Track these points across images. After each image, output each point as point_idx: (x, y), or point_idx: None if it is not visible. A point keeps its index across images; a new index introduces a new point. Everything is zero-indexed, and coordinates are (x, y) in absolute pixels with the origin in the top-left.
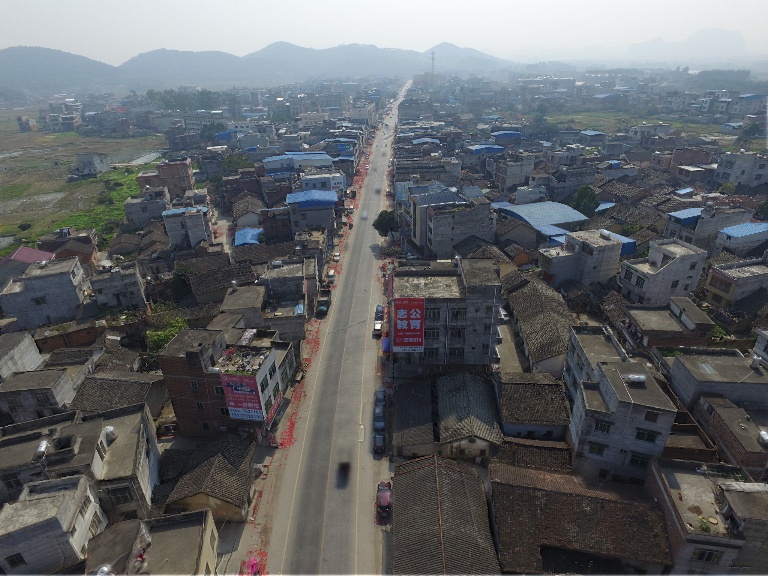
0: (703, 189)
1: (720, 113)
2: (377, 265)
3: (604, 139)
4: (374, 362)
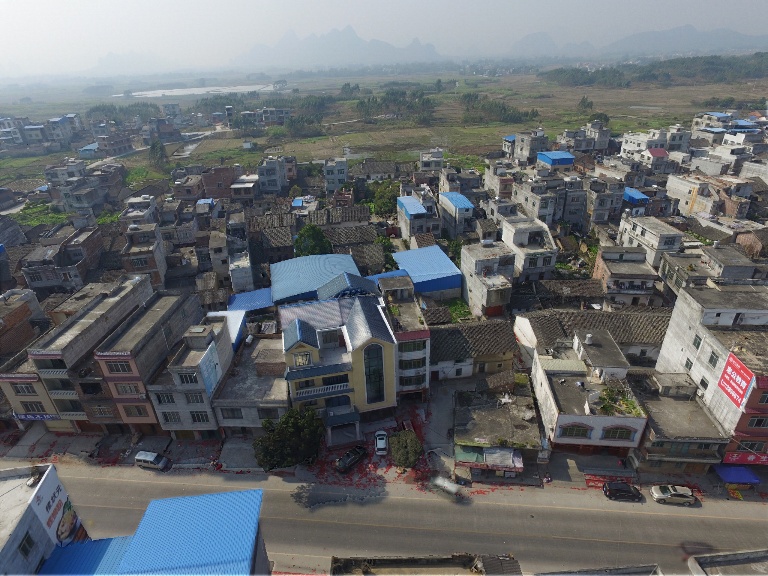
0: (291, 197)
1: (39, 141)
2: (413, 493)
3: (10, 195)
4: (766, 506)
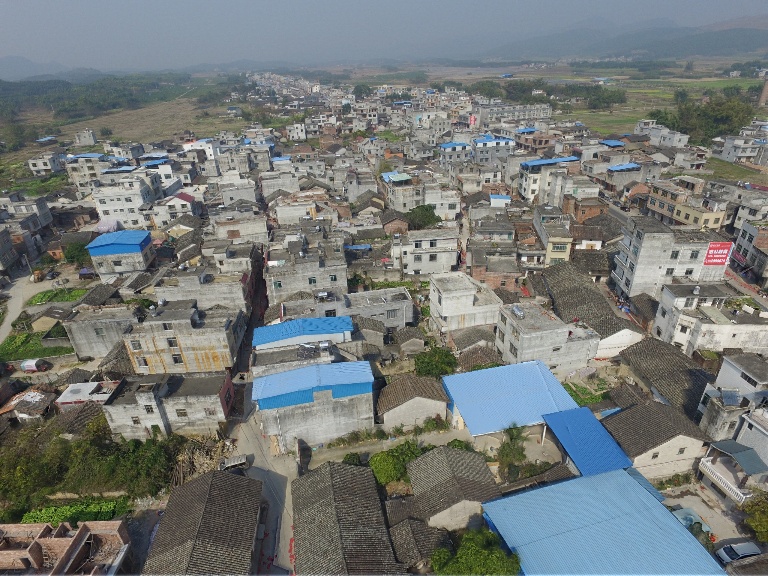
0: None
1: None
2: None
3: None
4: None
